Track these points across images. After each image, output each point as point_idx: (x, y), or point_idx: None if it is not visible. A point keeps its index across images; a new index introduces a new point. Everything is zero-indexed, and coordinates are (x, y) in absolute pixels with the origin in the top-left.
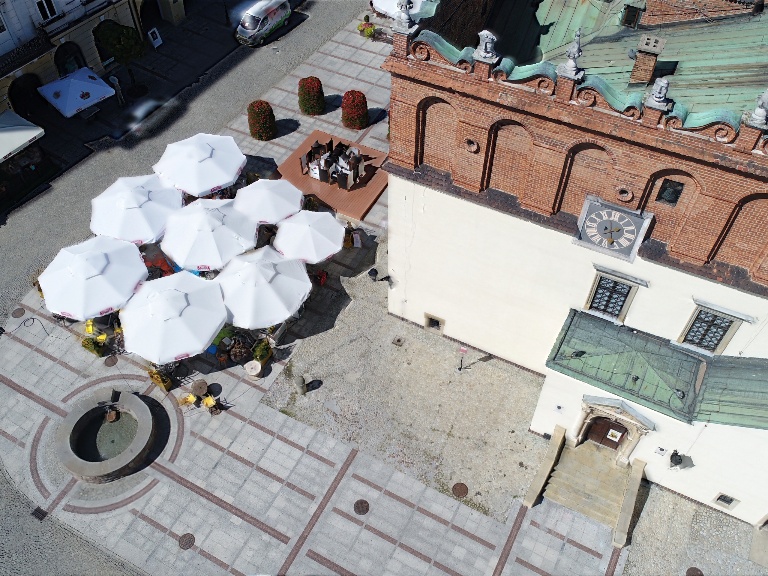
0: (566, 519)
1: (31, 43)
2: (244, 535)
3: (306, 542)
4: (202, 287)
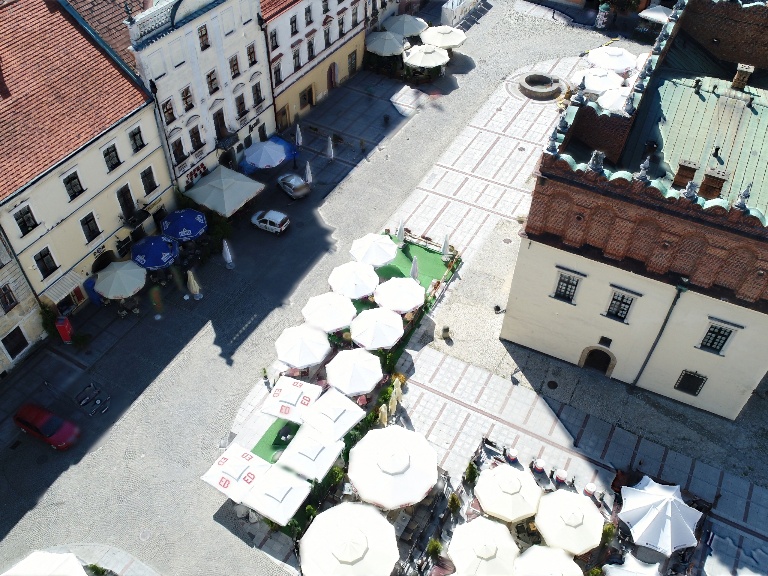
0: (528, 205)
1: (749, 1)
2: (504, 122)
3: (504, 136)
4: (614, 81)
